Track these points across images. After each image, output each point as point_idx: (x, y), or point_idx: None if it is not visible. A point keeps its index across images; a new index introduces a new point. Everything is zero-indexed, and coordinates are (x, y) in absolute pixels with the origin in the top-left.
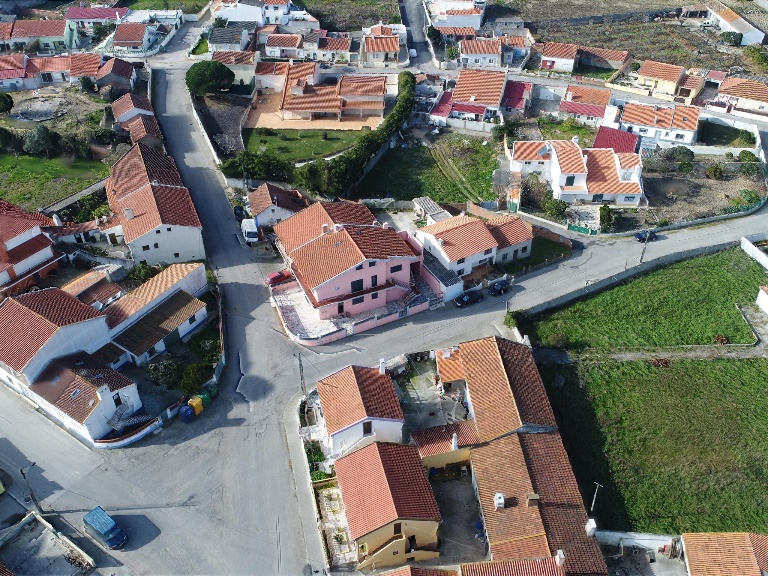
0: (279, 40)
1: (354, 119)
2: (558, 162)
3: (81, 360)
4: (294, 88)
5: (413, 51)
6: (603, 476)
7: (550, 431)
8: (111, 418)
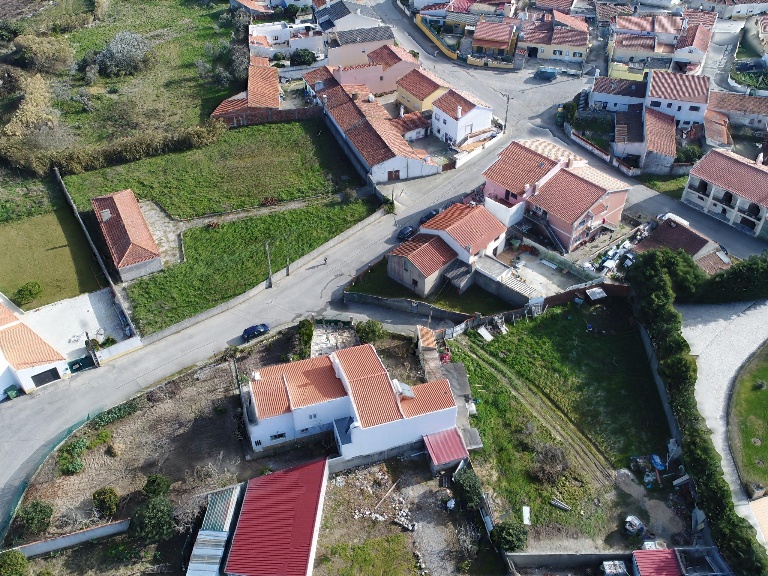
0: None
1: None
2: None
3: (636, 90)
4: None
5: None
6: None
7: None
8: None
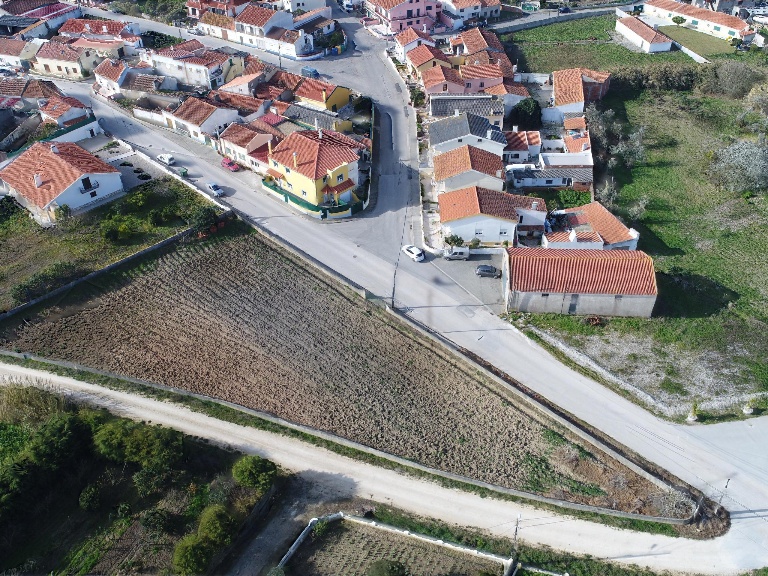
0: None
1: None
2: None
3: None
4: None
5: None
6: (525, 69)
7: (501, 52)
8: (303, 48)
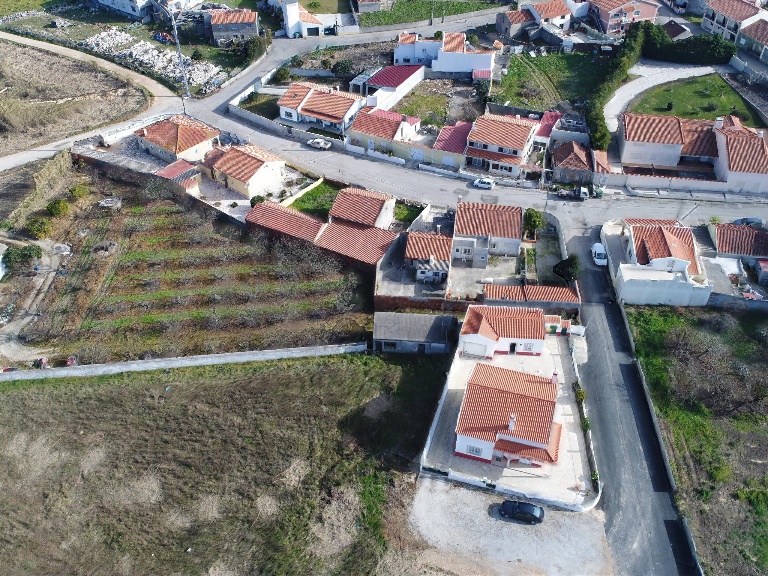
0: None
1: None
2: None
3: None
4: None
5: (600, 243)
6: None
7: None
8: None
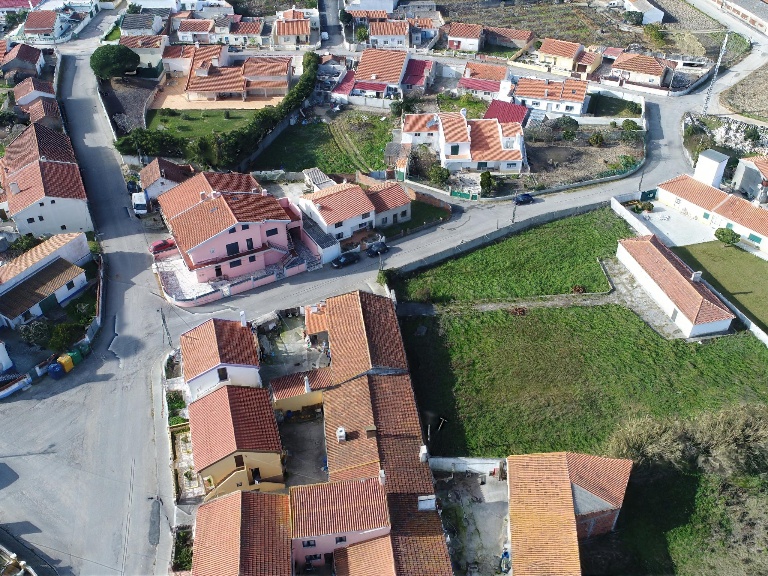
0: (191, 25)
1: (259, 99)
2: (443, 132)
3: None
4: (198, 70)
5: (324, 34)
6: (449, 412)
7: (400, 373)
8: None
